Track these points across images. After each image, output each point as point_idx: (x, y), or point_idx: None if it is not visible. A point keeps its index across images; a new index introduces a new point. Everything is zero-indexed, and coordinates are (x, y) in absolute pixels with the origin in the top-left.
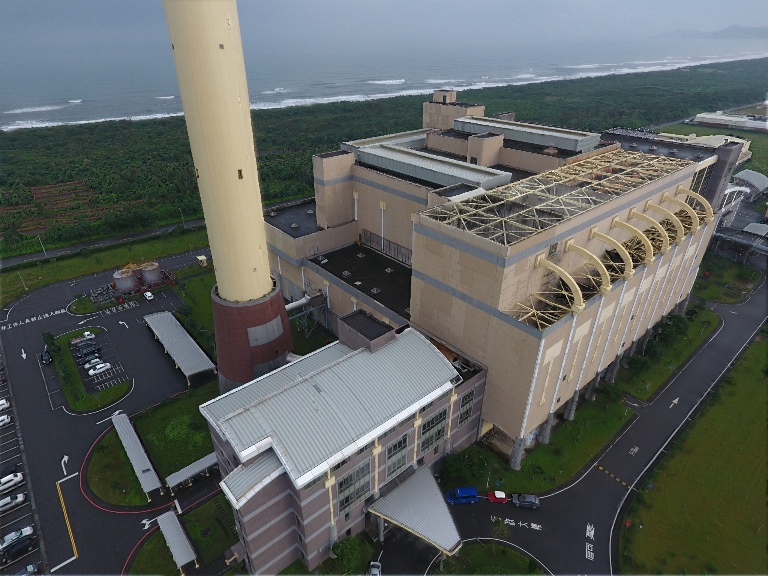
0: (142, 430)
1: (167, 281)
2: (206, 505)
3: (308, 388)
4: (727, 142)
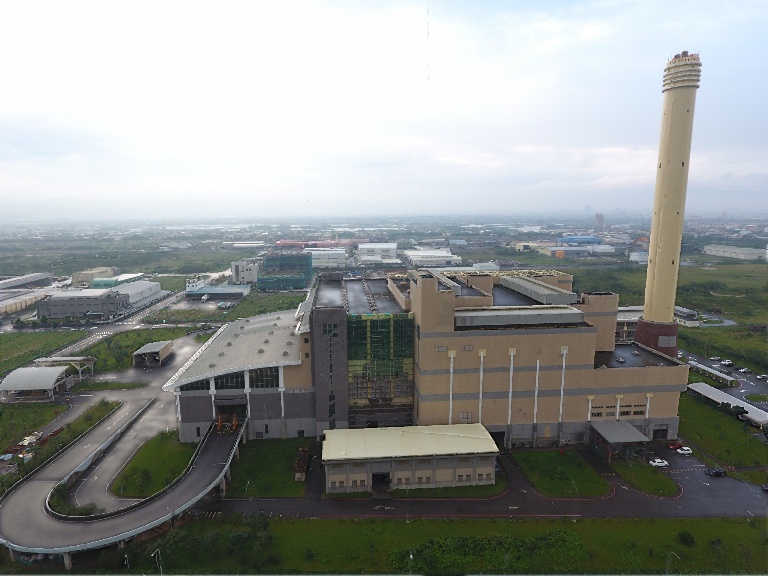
0: (717, 382)
1: None
2: None
3: None
4: None
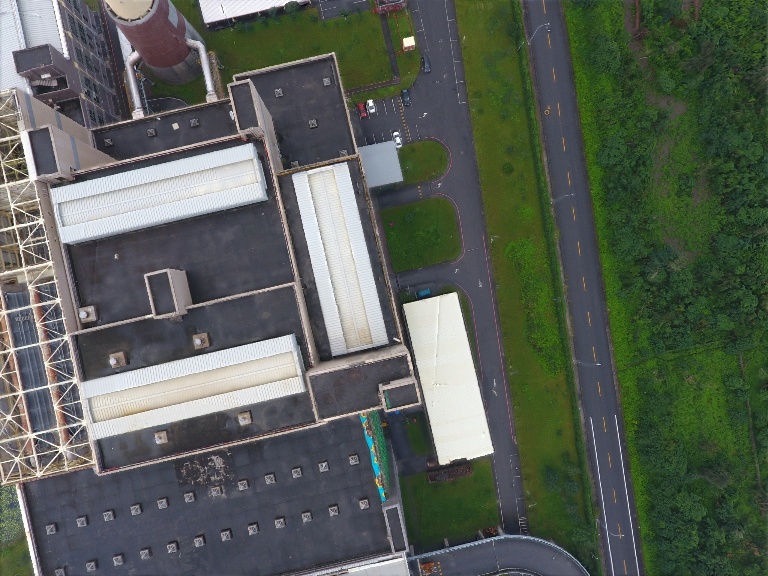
0: None
1: (377, 4)
2: (96, 1)
3: (6, 8)
4: None
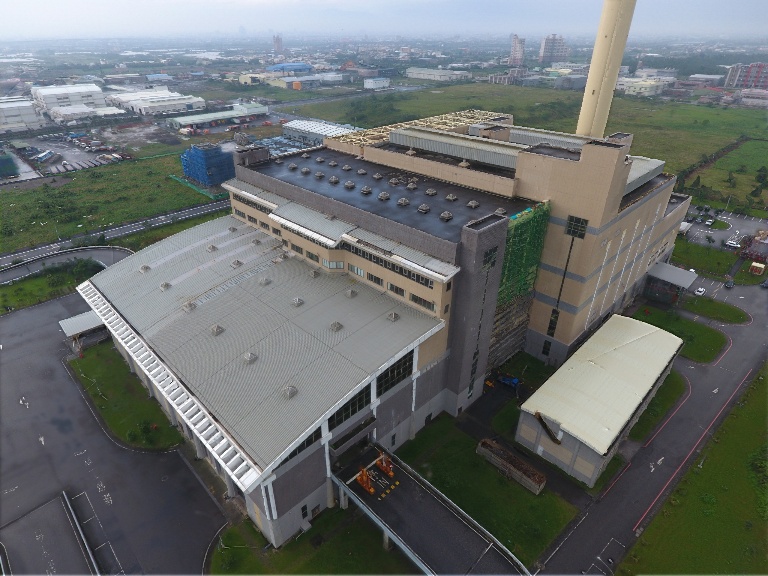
0: None
1: None
2: None
3: None
4: (250, 150)
